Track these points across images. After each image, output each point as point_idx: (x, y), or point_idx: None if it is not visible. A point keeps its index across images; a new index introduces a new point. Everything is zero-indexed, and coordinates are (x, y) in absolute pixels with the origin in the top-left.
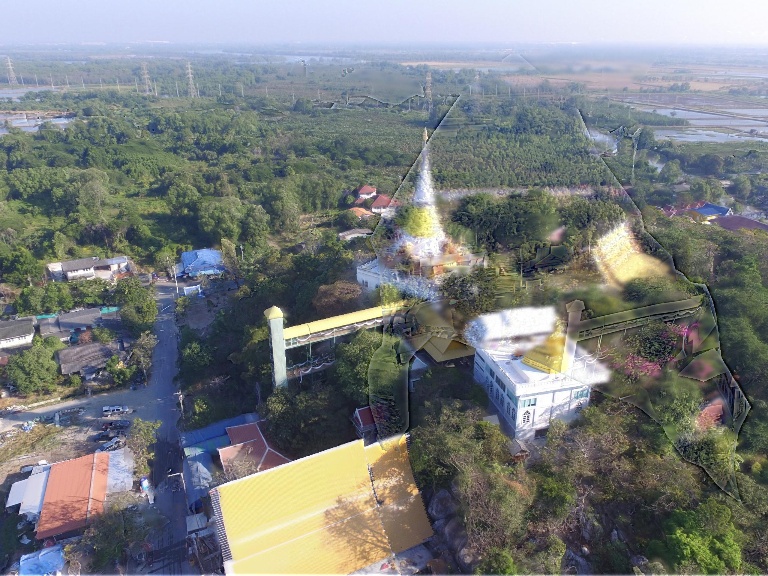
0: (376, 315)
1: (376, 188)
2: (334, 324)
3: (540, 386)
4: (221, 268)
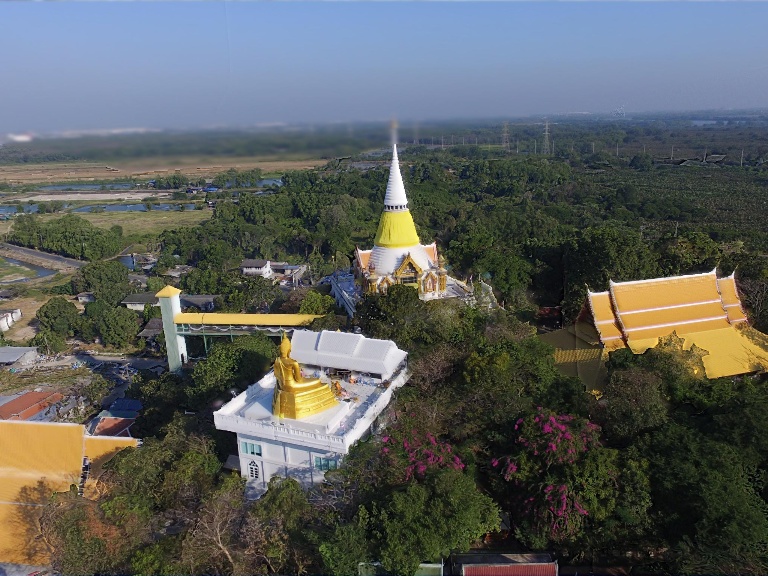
0: (281, 322)
1: None
2: (230, 320)
3: (246, 425)
4: None
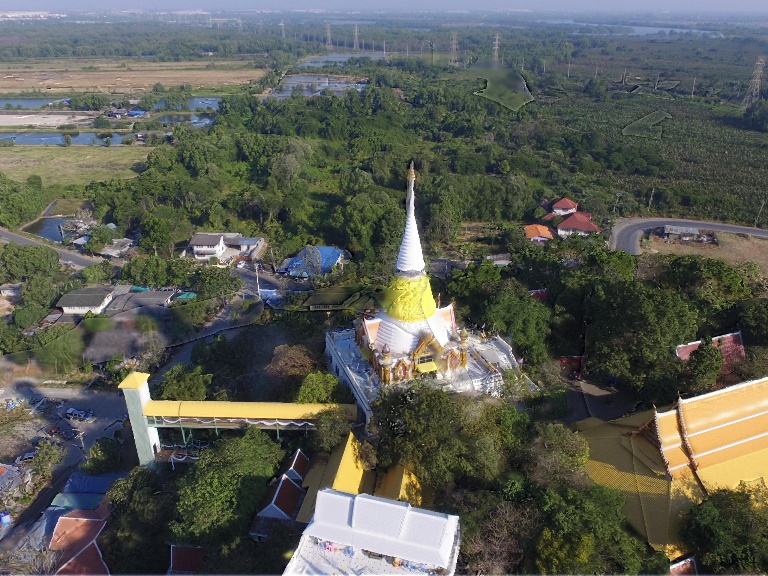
0: (277, 415)
1: (578, 203)
2: (214, 412)
3: None
4: (325, 272)
